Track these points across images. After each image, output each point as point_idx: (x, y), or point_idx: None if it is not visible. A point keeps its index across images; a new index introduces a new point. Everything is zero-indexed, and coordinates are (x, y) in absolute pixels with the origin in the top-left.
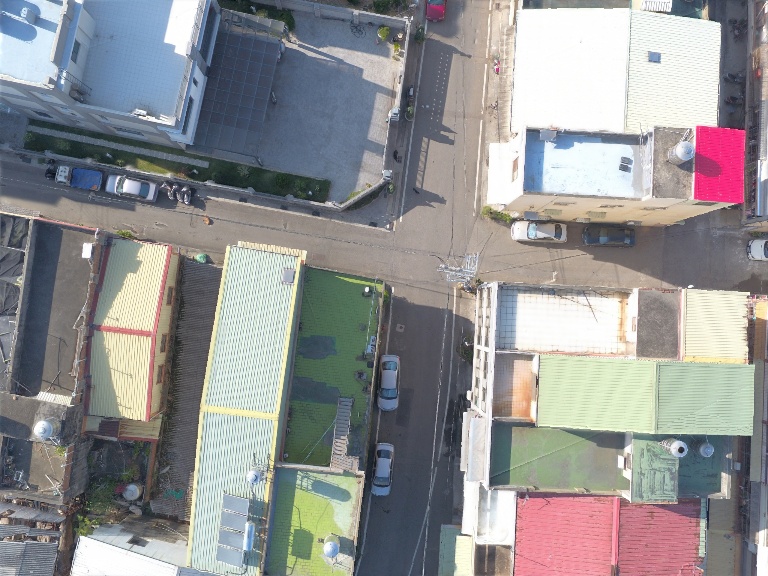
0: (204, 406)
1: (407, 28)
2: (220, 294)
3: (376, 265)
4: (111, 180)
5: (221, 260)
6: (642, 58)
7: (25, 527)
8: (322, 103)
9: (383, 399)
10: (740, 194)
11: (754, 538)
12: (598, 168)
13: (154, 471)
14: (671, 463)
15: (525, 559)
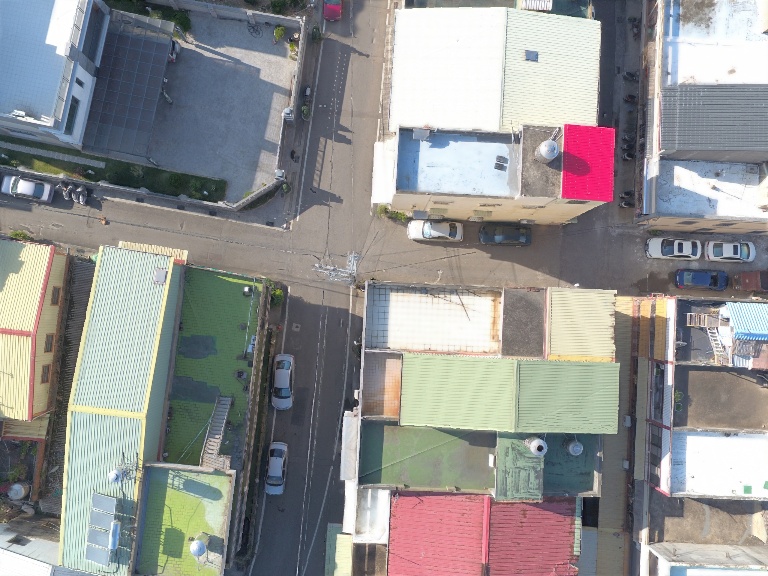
0: (72, 405)
1: (301, 28)
2: (91, 294)
3: (272, 265)
4: (7, 181)
5: None
6: (518, 57)
7: None
8: (219, 103)
9: (277, 398)
10: (609, 192)
11: (638, 536)
12: (473, 167)
13: (42, 470)
14: (536, 461)
15: (398, 557)
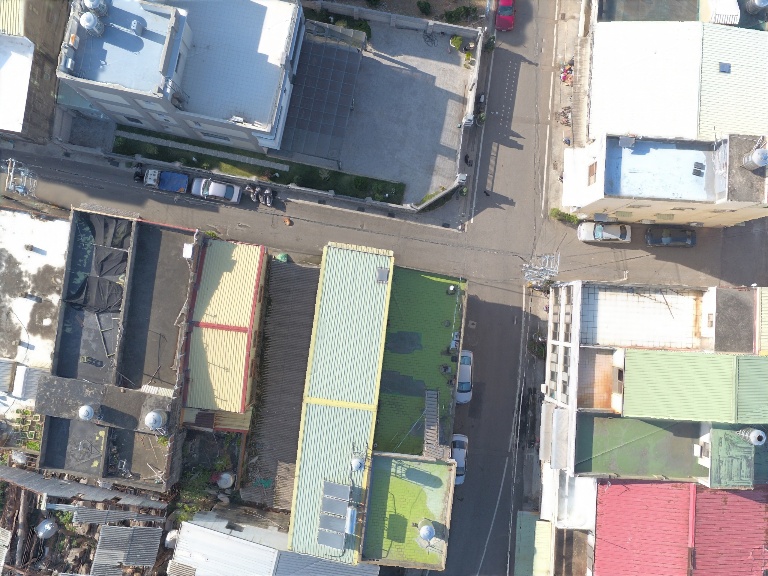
0: (307, 398)
1: (479, 38)
2: (319, 292)
3: (449, 264)
4: (196, 183)
5: (301, 259)
6: (713, 69)
7: (133, 513)
8: (397, 109)
9: (457, 392)
10: None
11: None
12: (673, 173)
13: (244, 461)
14: (747, 451)
15: (605, 542)
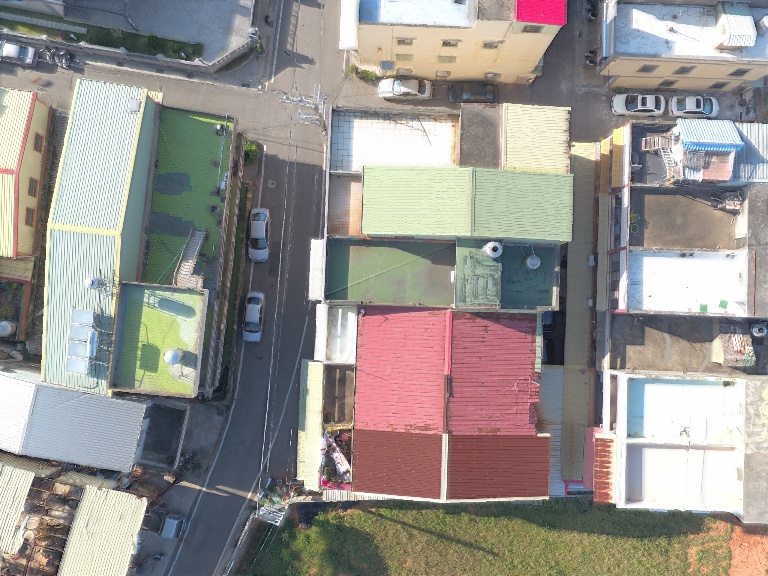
0: (51, 224)
1: None
2: (69, 123)
3: (249, 125)
4: None
5: None
6: None
7: None
8: None
9: (253, 250)
10: (563, 15)
11: (600, 365)
12: (434, 1)
13: (29, 313)
14: (493, 269)
15: (365, 374)
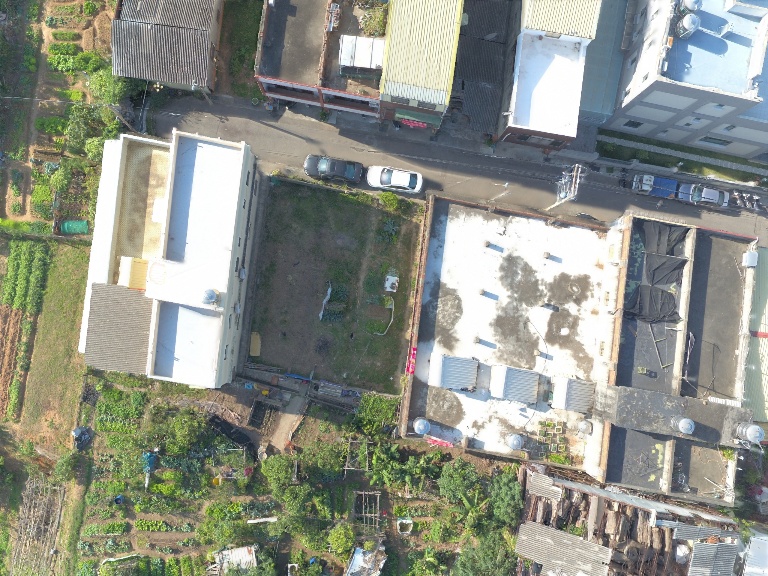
0: None
1: None
2: None
3: None
4: (682, 189)
5: None
6: None
7: (718, 529)
8: None
9: None
10: None
11: None
12: None
13: None
14: None
15: None
